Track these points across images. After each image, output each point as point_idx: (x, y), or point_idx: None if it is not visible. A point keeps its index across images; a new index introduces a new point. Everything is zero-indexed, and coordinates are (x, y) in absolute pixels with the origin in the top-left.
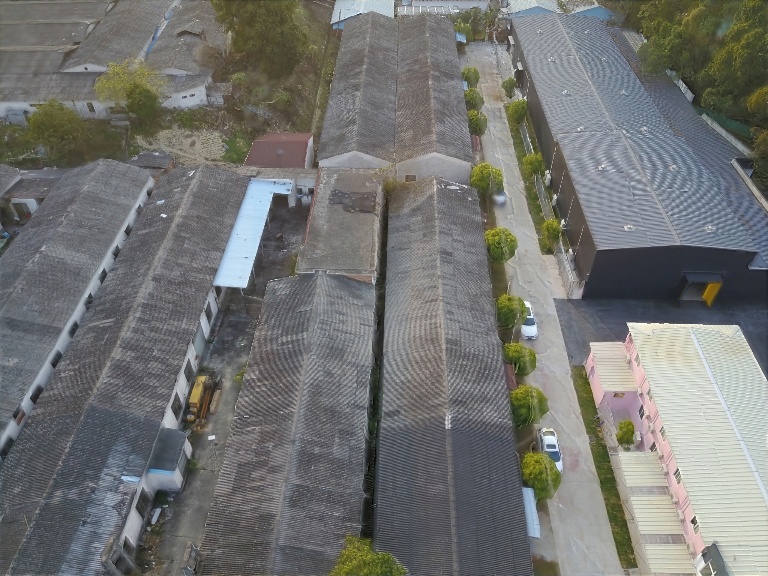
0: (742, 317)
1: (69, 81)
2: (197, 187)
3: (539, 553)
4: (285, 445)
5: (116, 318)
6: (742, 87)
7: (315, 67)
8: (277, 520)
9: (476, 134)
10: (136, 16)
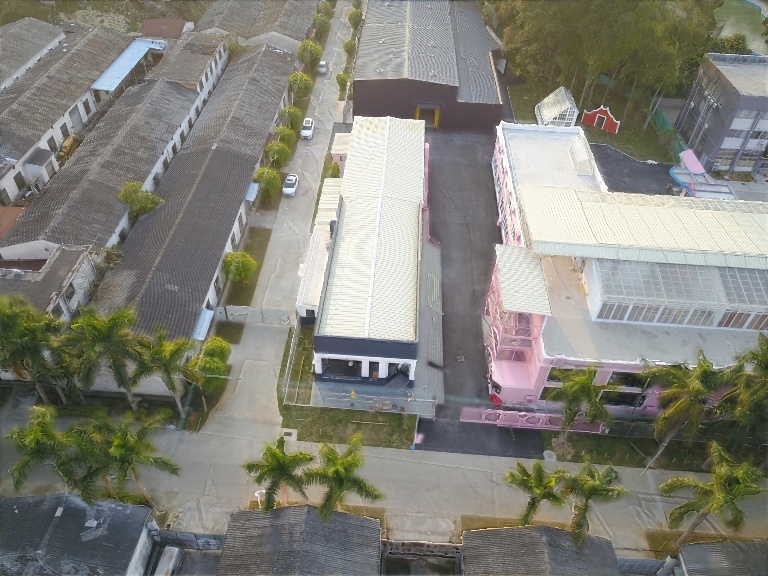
0: (456, 137)
1: None
2: (92, 36)
3: (263, 225)
4: (107, 146)
5: (18, 93)
6: None
7: None
8: (91, 170)
9: (320, 32)
10: None
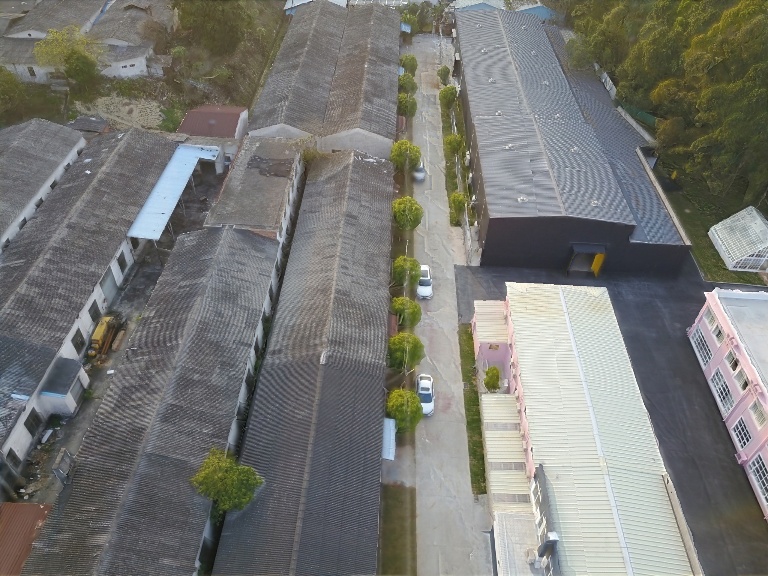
0: (624, 287)
1: (12, 46)
2: (124, 148)
3: (400, 479)
4: (166, 371)
5: (27, 259)
6: (652, 82)
7: (263, 49)
8: (147, 432)
9: (406, 116)
10: None
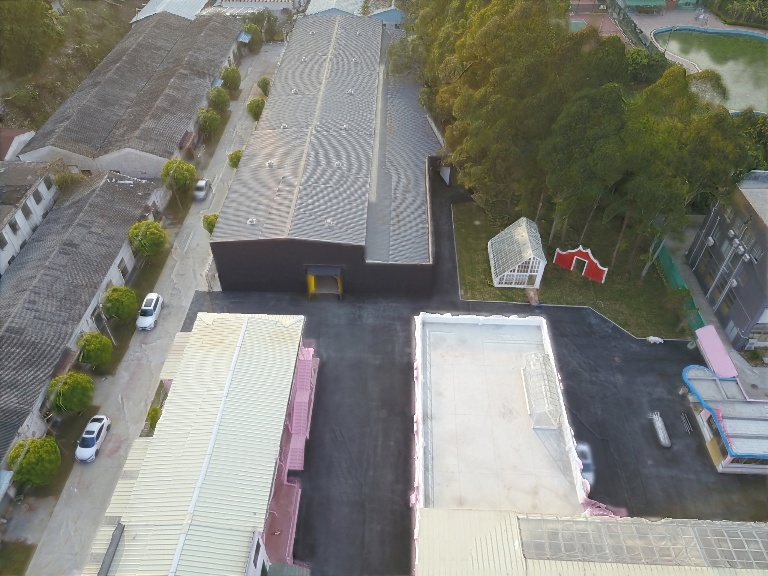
0: (368, 310)
1: None
2: None
3: (25, 535)
4: None
5: None
6: None
7: (92, 65)
8: None
9: (207, 131)
10: None
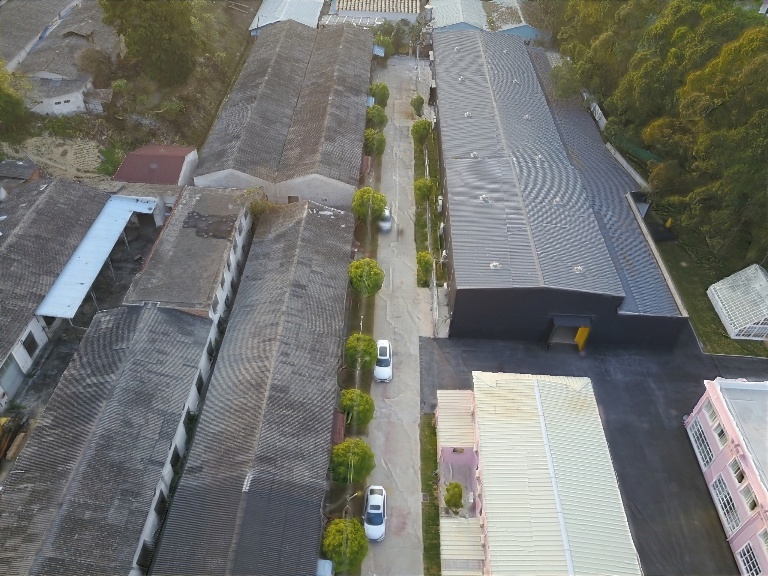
0: (612, 363)
1: None
2: (44, 203)
3: None
4: (50, 509)
5: None
6: (643, 117)
7: (223, 75)
8: None
9: (373, 154)
10: (25, 13)
